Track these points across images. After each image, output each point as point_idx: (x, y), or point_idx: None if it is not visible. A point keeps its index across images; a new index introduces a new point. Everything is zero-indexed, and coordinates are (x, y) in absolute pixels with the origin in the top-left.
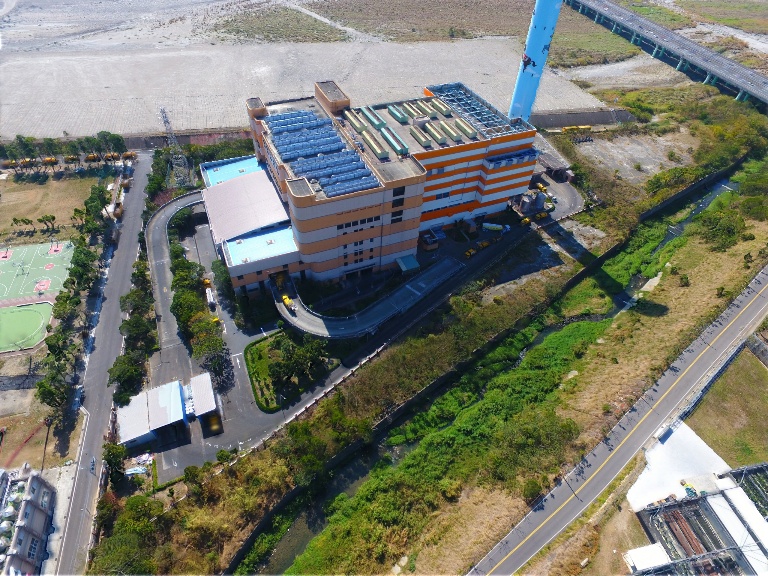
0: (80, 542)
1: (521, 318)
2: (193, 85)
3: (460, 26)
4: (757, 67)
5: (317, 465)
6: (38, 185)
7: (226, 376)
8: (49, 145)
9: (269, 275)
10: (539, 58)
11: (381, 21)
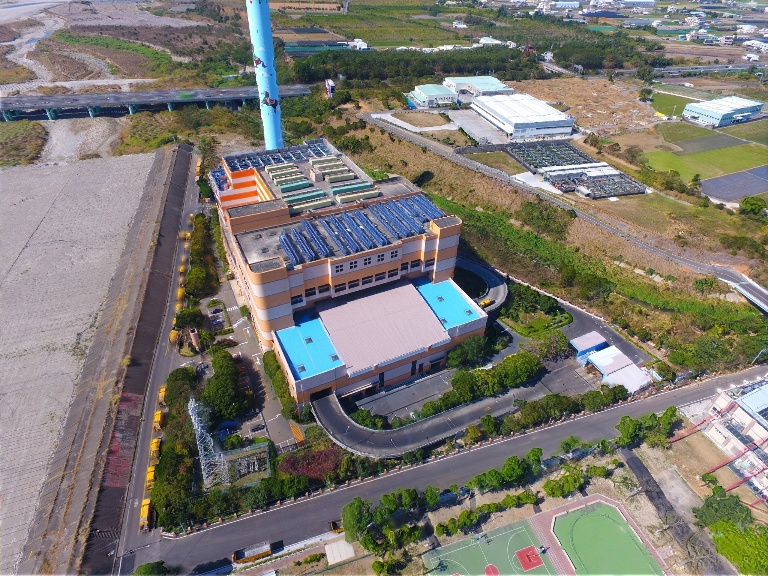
0: (715, 384)
1: None
2: None
3: None
4: None
5: None
6: None
7: None
8: None
9: None
10: None
11: None
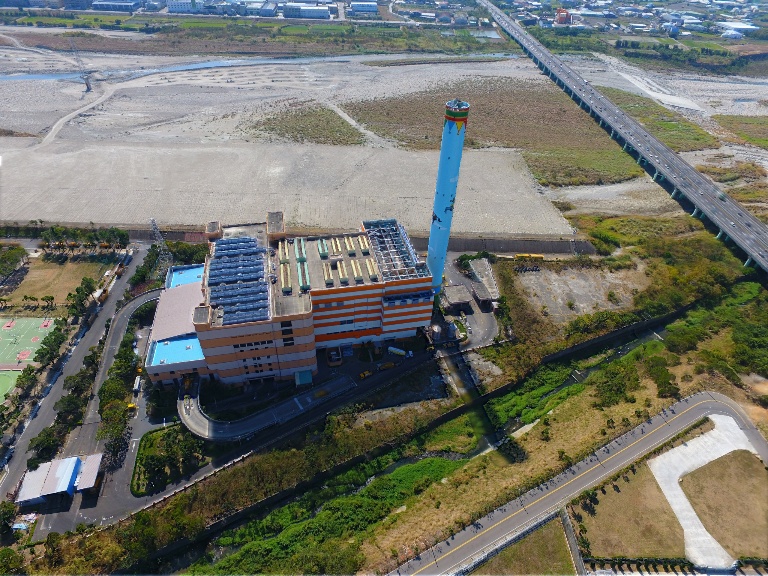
0: None
1: (380, 446)
2: (213, 181)
3: (473, 135)
4: (764, 200)
5: (141, 552)
6: (57, 265)
7: (119, 457)
8: (73, 235)
9: (182, 374)
10: (443, 216)
11: (402, 125)
